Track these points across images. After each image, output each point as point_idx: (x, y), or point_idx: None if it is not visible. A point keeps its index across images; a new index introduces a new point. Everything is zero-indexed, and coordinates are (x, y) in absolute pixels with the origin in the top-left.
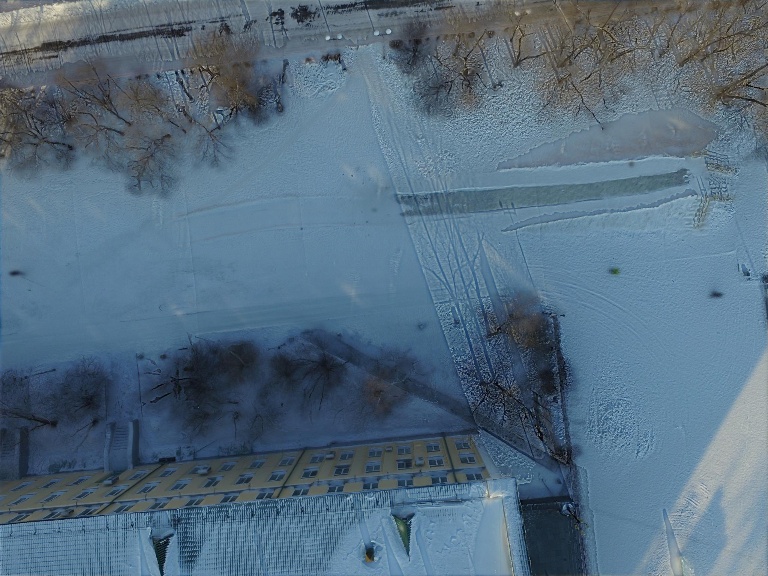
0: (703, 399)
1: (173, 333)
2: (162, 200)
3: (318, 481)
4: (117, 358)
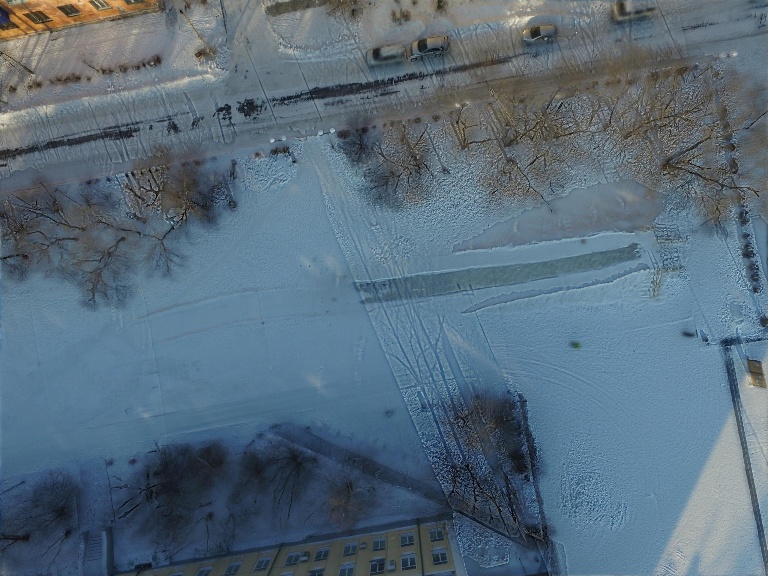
0: (672, 466)
1: (141, 436)
2: (121, 303)
3: None
4: (86, 465)
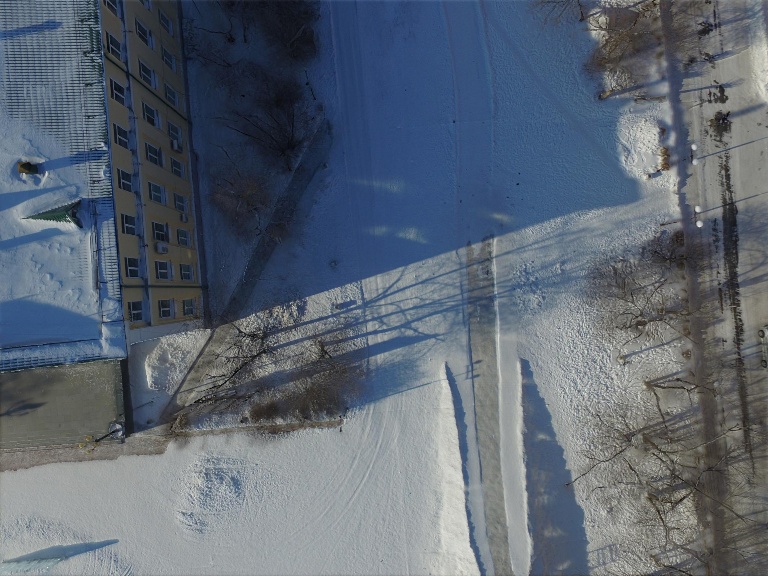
0: None
1: None
2: None
3: (135, 117)
4: None
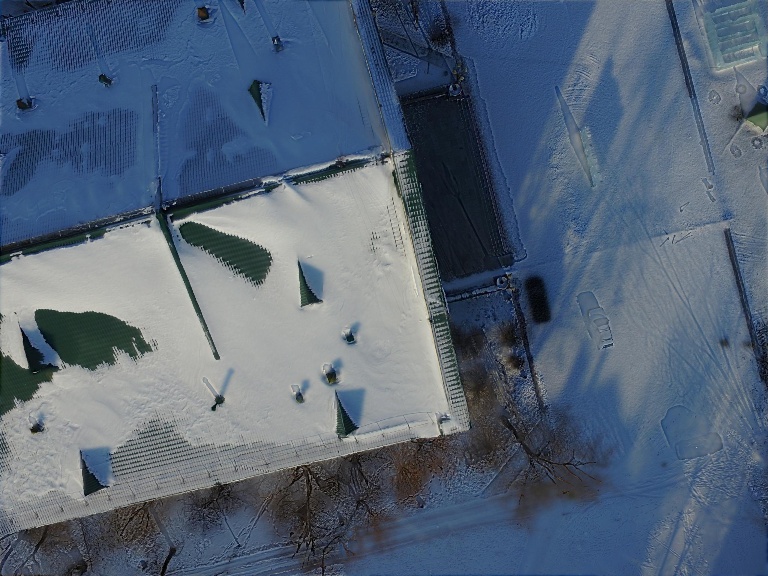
0: None
1: None
2: None
3: None
4: None
